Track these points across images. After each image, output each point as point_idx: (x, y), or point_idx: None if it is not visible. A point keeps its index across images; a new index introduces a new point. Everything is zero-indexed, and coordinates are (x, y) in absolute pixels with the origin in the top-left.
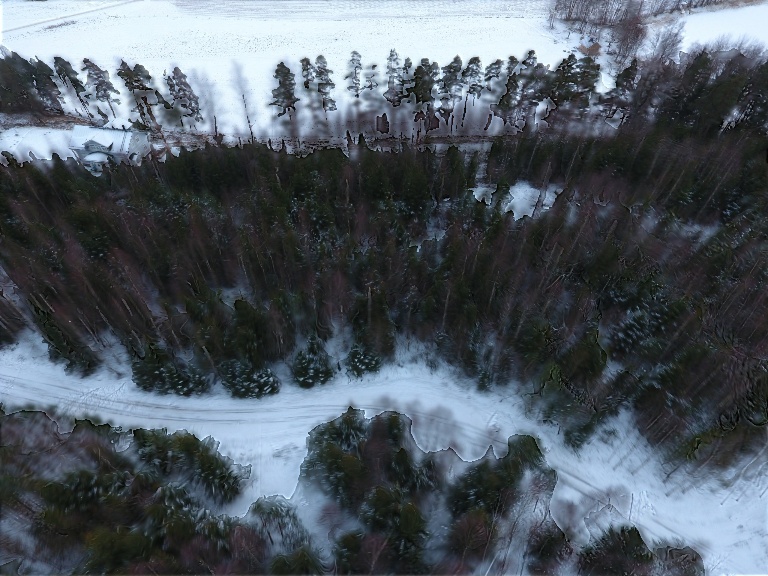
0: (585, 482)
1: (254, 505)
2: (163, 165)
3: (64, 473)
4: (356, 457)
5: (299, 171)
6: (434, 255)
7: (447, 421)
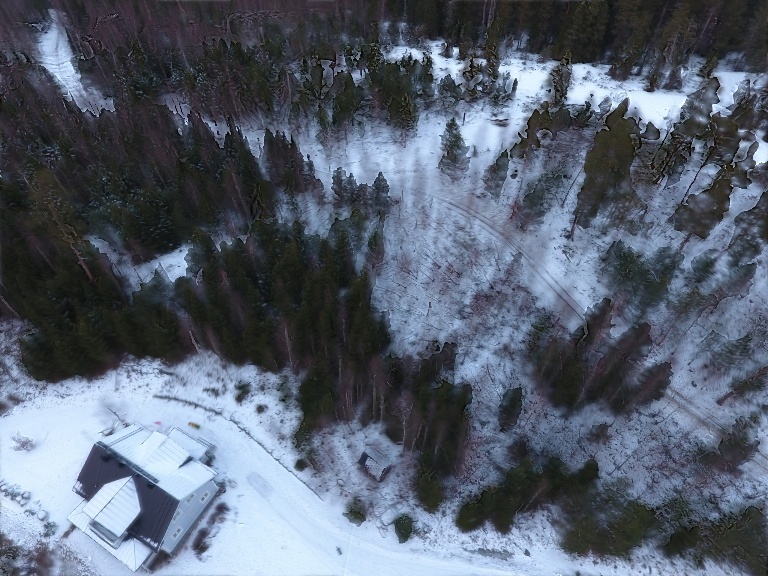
0: (74, 94)
1: (181, 77)
2: (103, 259)
3: (230, 74)
4: (138, 69)
5: (0, 187)
6: (6, 129)
7: (98, 113)
